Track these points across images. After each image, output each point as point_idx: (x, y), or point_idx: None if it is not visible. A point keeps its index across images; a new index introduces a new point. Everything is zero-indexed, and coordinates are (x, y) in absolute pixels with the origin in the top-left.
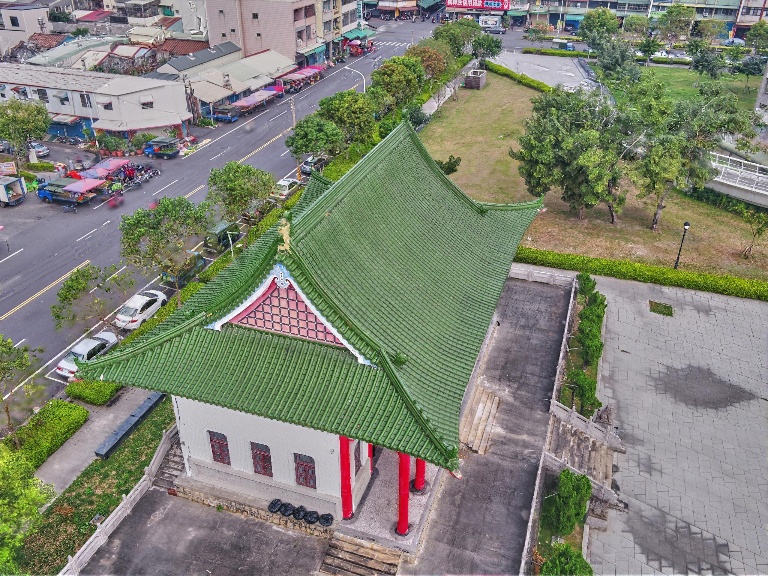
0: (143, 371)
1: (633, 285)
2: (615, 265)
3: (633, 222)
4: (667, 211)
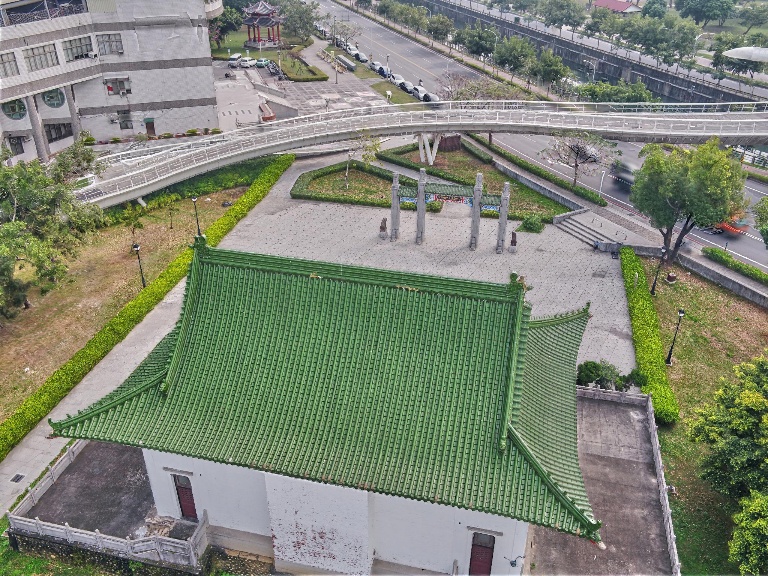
0: (570, 485)
1: (155, 316)
2: (129, 315)
3: (32, 296)
4: (21, 273)
